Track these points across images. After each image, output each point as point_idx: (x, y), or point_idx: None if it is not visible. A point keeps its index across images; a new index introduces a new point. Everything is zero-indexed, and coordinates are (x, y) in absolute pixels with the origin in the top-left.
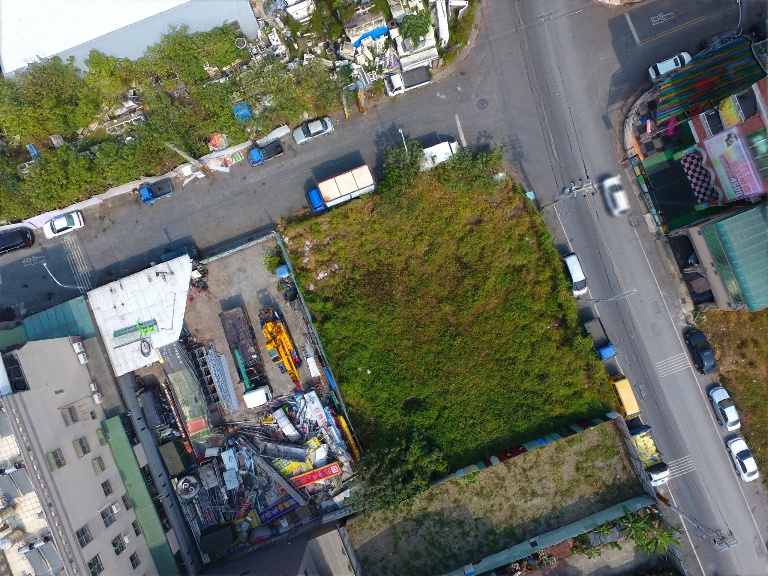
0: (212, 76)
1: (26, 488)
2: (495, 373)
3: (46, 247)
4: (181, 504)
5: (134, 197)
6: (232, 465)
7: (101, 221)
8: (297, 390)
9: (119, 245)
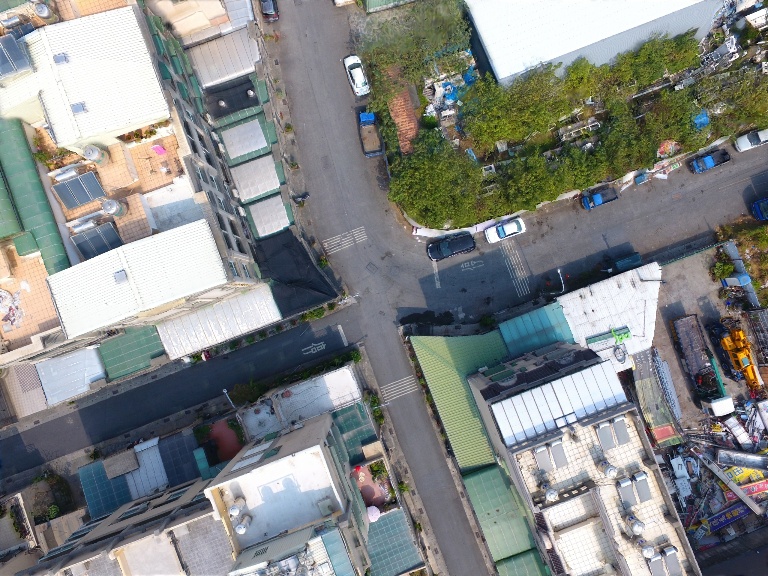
0: (654, 83)
1: (644, 496)
2: None
3: (484, 252)
4: None
5: (571, 203)
6: (682, 473)
7: (539, 227)
8: (740, 398)
9: (557, 251)
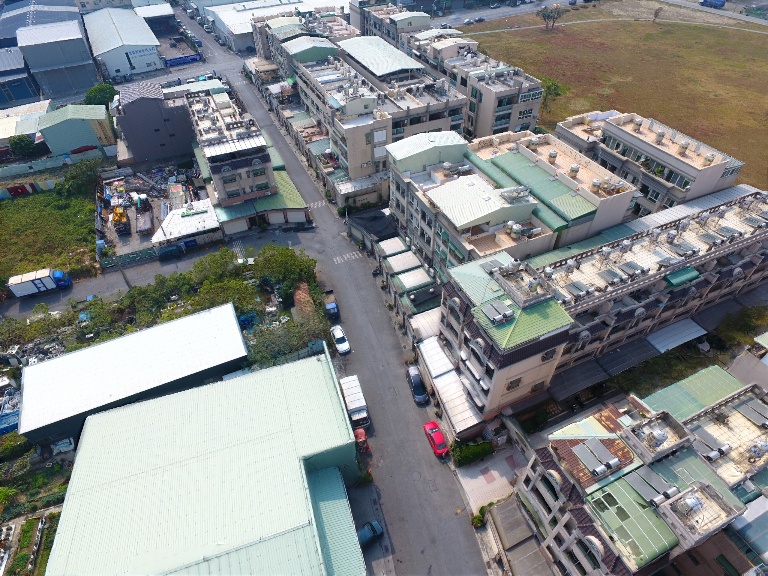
0: None
1: None
2: (5, 219)
3: None
4: (199, 171)
5: None
6: None
7: None
8: None
9: None
